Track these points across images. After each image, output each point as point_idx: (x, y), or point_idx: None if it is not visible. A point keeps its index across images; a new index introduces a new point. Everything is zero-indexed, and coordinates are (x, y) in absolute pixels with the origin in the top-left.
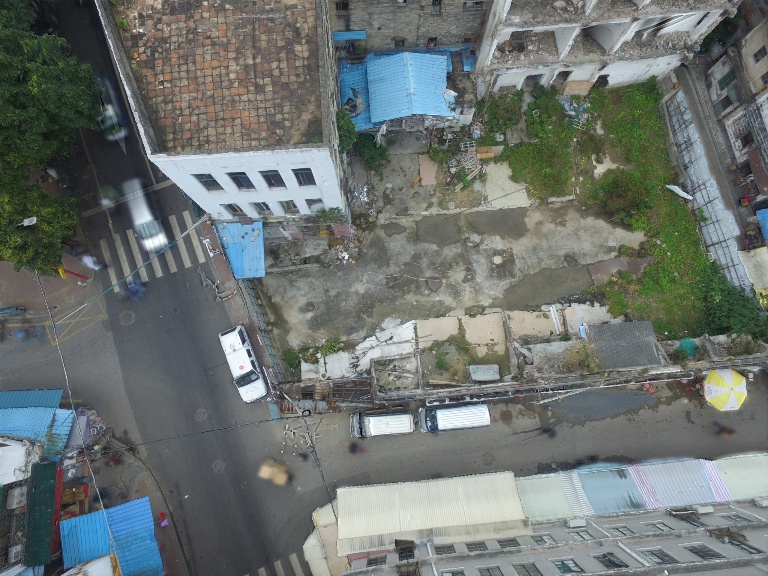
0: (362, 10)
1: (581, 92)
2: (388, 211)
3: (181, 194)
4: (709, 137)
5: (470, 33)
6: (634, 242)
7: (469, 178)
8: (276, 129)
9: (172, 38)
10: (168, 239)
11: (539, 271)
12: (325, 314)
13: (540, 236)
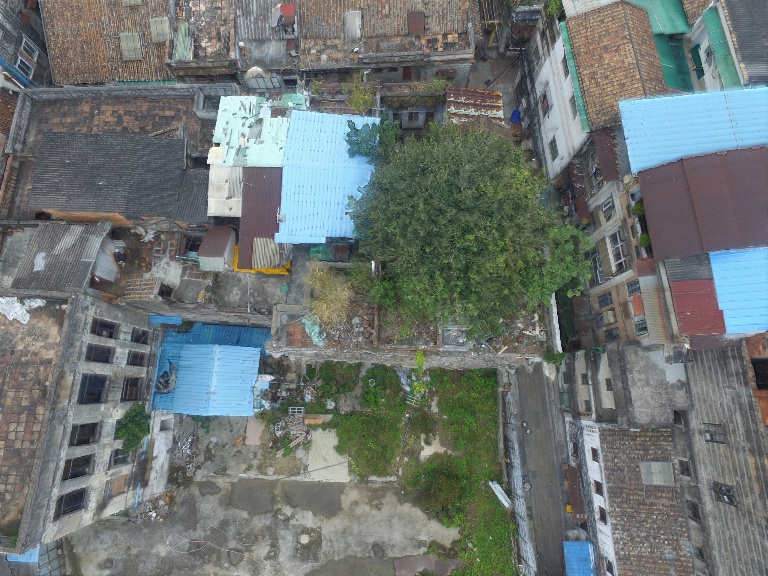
0: (167, 312)
1: None
2: (207, 468)
3: None
4: (550, 425)
5: None
6: (447, 539)
7: (292, 445)
8: None
9: None
10: None
11: (344, 558)
12: (121, 574)
13: (352, 518)
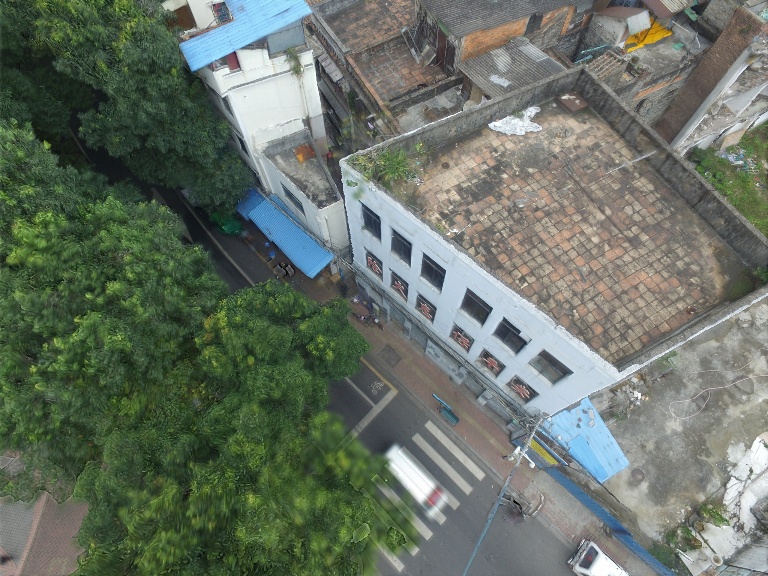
0: None
1: (735, 142)
2: None
3: (410, 404)
4: None
5: (651, 123)
6: None
7: None
8: (689, 279)
9: (497, 225)
10: (426, 467)
11: None
12: (660, 476)
13: None
